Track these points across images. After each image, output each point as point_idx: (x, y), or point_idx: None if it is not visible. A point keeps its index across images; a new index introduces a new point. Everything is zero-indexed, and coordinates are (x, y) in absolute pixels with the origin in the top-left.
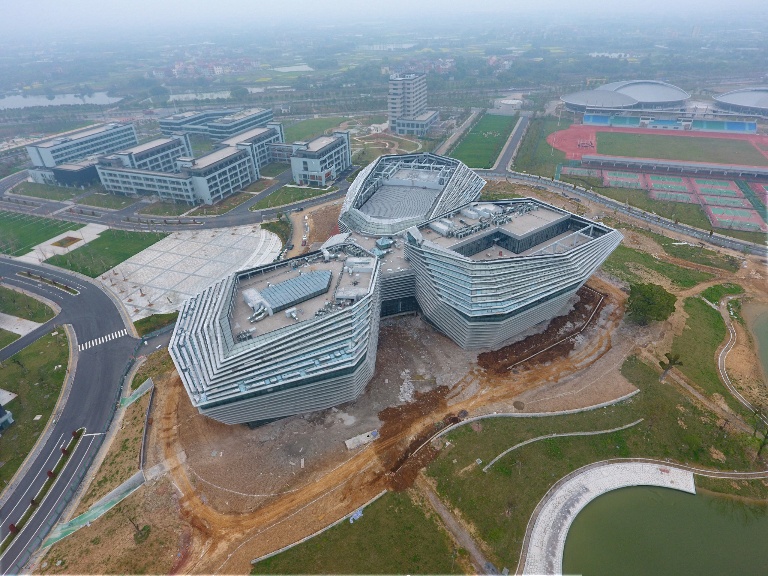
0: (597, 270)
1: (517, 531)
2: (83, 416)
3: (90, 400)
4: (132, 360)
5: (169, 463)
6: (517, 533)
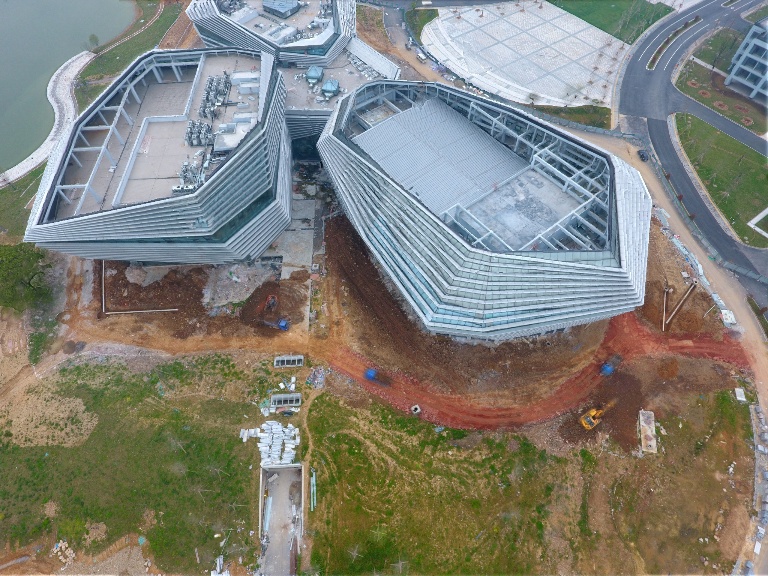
0: (133, 359)
1: (82, 100)
2: None
3: None
4: (383, 5)
5: None
6: (81, 100)
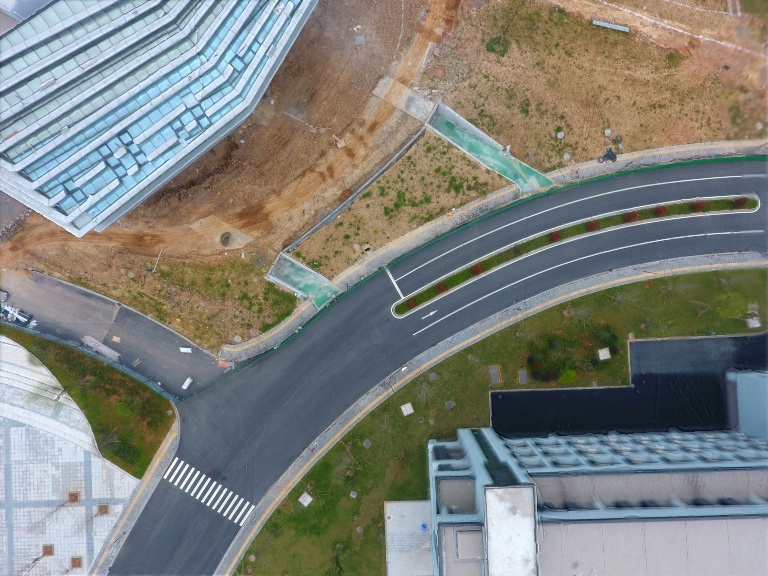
0: None
1: None
2: (375, 337)
3: (343, 359)
4: None
5: (399, 97)
6: None
